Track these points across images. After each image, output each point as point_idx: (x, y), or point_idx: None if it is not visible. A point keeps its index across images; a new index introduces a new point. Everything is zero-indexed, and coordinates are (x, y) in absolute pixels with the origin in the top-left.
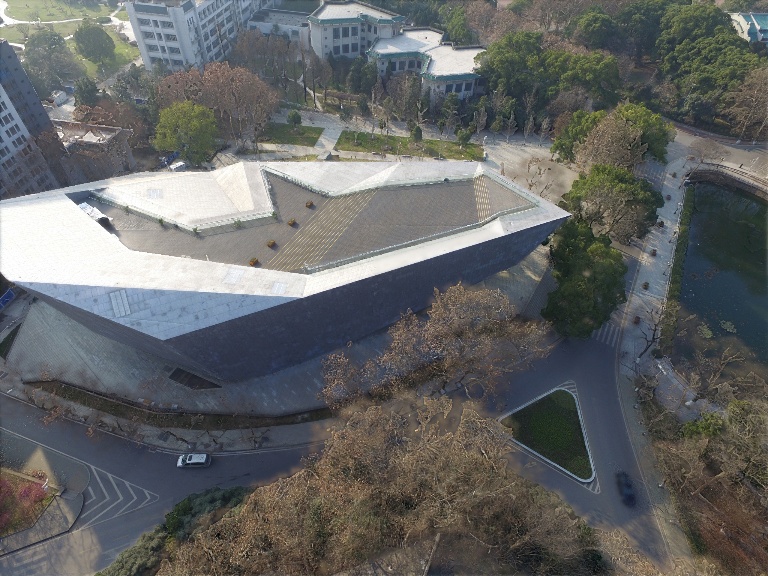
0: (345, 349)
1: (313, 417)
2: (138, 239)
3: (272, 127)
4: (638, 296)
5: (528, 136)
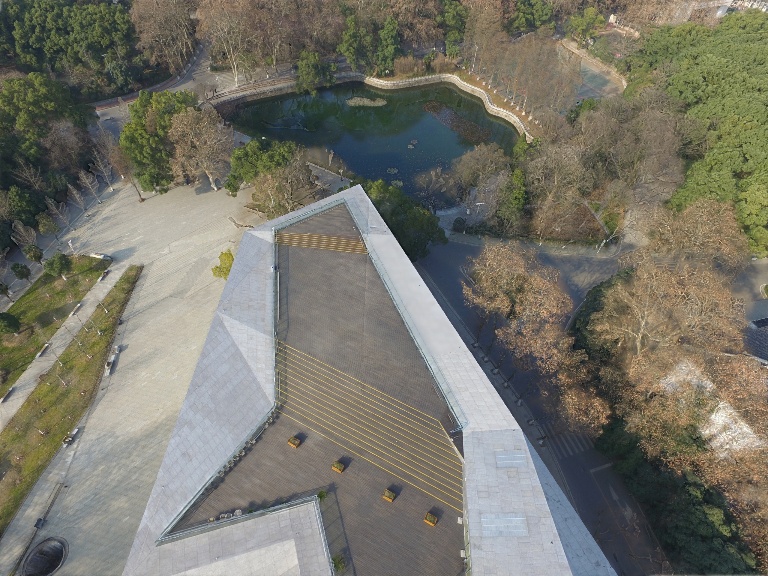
0: None
1: None
2: None
3: None
4: None
5: (84, 205)
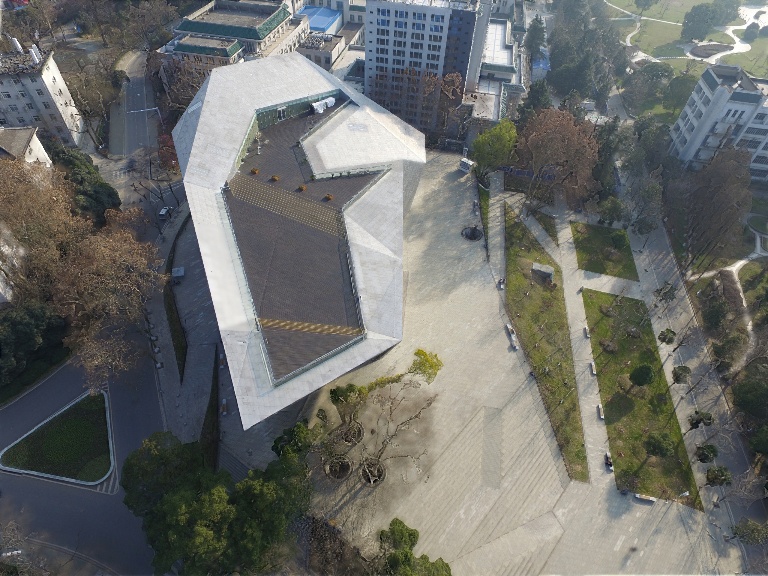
0: None
1: (169, 262)
2: (295, 124)
3: None
4: None
5: None
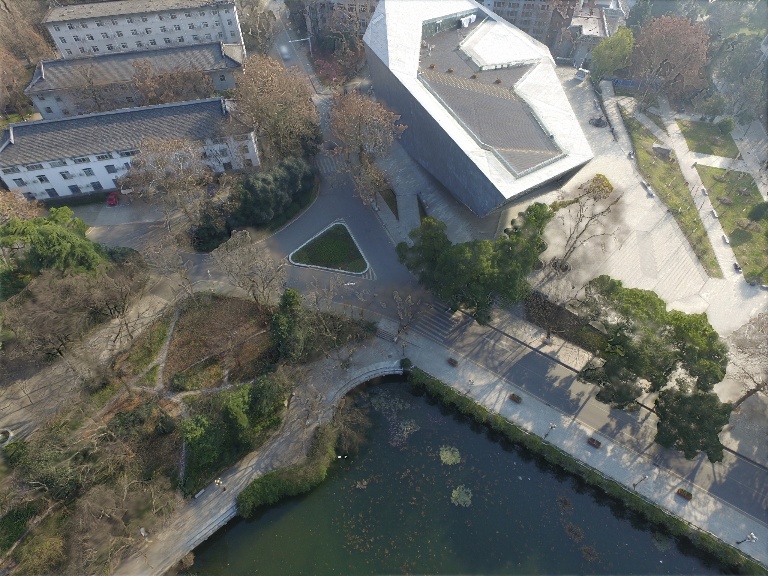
0: (406, 154)
1: None
2: (449, 35)
3: (714, 127)
4: (496, 382)
5: None
